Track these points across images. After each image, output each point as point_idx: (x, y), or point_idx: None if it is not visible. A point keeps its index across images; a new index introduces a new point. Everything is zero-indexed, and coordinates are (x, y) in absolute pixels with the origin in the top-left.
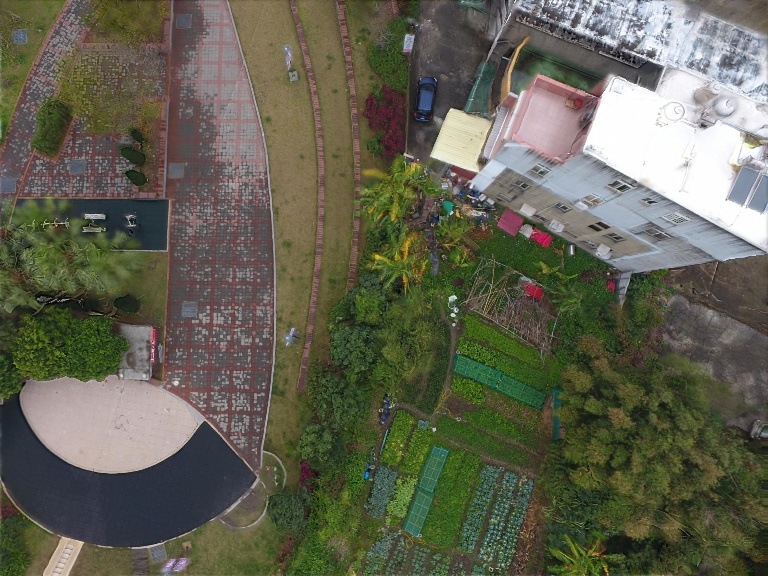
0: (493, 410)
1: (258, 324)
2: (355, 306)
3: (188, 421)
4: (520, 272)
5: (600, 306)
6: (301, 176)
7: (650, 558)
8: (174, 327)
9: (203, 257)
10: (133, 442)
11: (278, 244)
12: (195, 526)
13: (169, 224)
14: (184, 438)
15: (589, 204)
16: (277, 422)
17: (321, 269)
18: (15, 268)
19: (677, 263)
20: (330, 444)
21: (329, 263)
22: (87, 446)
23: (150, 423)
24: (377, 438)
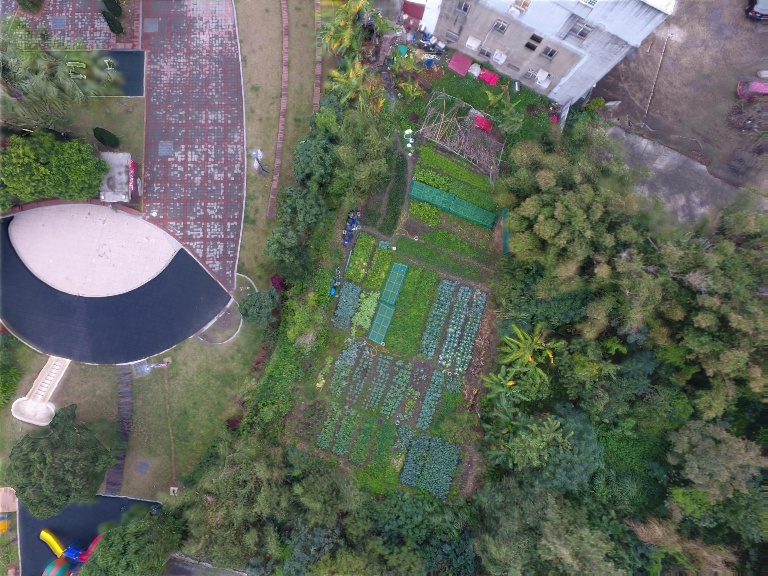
0: (448, 231)
1: (230, 161)
2: (316, 126)
3: (166, 248)
4: (469, 104)
5: (543, 132)
6: (267, 28)
7: (589, 341)
8: (151, 164)
9: (177, 102)
10: (115, 268)
11: (247, 89)
12: (175, 343)
13: (145, 73)
14: (163, 264)
15: (521, 10)
16: (249, 247)
17: (287, 109)
18: (1, 75)
19: (604, 69)
20: (296, 249)
21: (294, 104)
22: (72, 273)
23: (131, 251)
24: (342, 258)
